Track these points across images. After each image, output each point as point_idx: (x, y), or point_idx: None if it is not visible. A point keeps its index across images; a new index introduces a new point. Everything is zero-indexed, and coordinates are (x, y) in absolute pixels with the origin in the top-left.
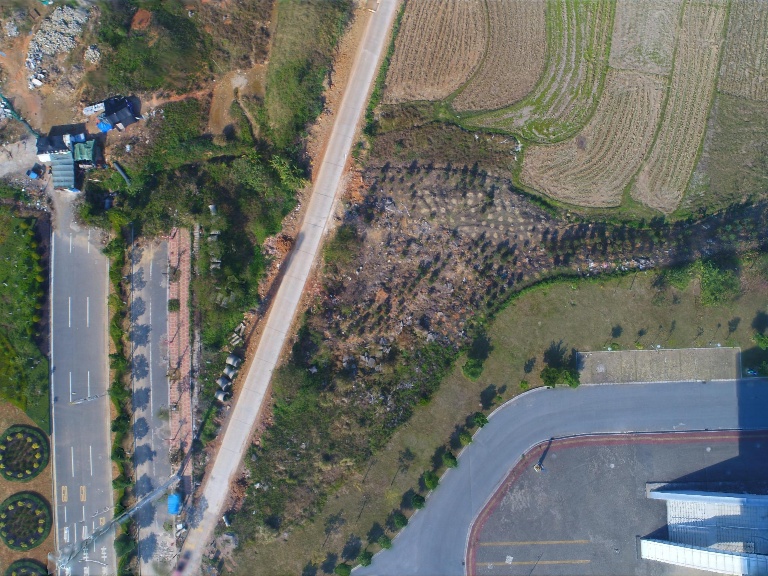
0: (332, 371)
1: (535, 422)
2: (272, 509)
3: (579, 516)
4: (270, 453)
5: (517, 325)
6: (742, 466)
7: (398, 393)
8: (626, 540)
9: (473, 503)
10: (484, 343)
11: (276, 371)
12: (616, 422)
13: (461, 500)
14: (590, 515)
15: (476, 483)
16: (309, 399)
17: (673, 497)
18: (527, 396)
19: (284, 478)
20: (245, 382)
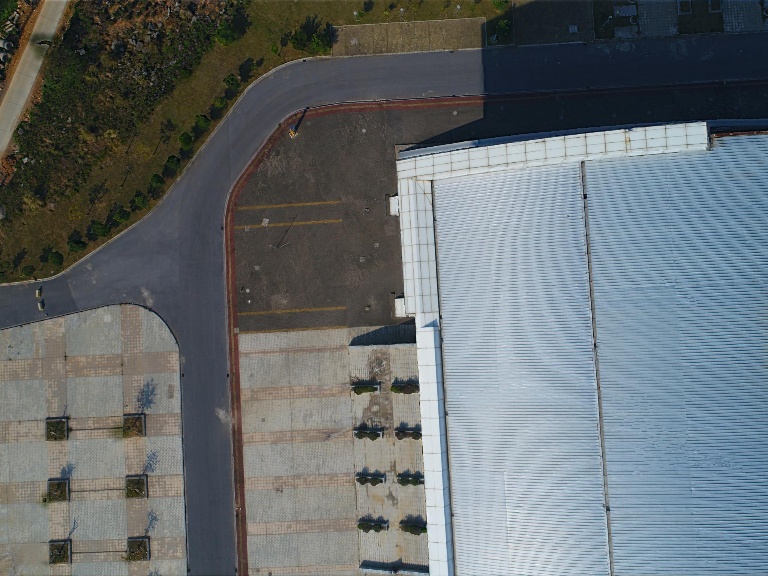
0: (101, 53)
1: (291, 93)
2: (38, 180)
3: (332, 178)
4: (38, 128)
5: (274, 2)
6: (486, 127)
7: (162, 71)
8: (376, 199)
9: (232, 171)
10: (243, 19)
11: (48, 56)
12: (368, 91)
13: (220, 168)
14: (342, 177)
15: (235, 152)
16: (75, 76)
17: (417, 152)
18: (284, 69)
19: (50, 150)
20: (18, 66)
